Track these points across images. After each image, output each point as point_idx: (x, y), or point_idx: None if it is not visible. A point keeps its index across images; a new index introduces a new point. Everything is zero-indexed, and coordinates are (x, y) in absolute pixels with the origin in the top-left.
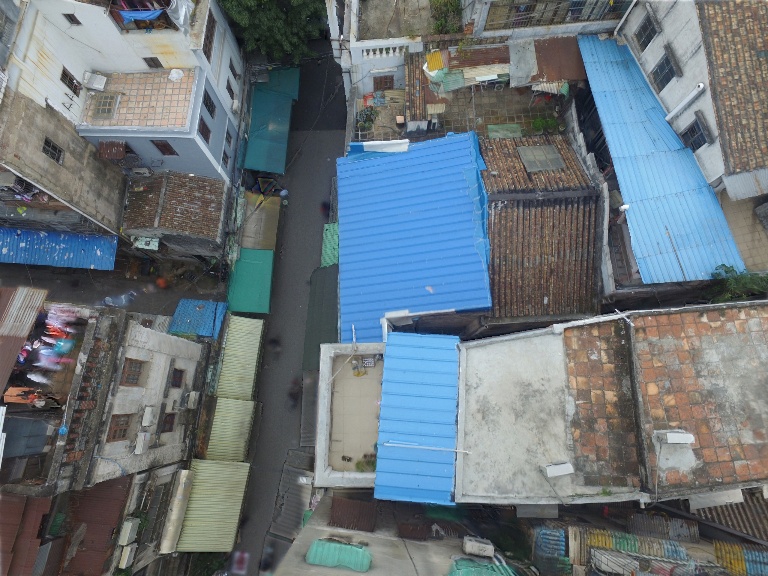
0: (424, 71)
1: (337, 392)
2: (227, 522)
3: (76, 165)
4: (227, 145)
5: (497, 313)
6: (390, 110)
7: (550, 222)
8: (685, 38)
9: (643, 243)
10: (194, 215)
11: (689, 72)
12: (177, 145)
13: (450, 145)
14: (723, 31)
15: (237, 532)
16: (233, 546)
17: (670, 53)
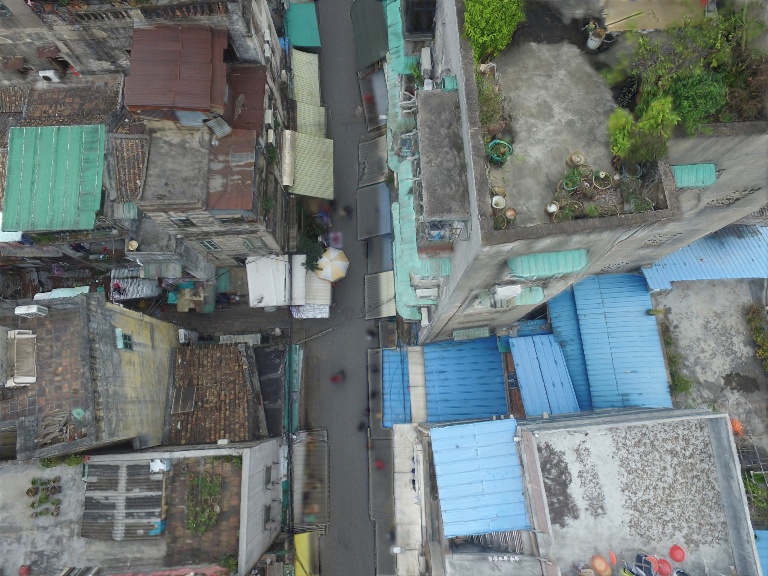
0: None
1: None
2: (325, 179)
3: None
4: None
5: None
6: None
7: None
8: None
9: None
10: None
11: None
12: None
13: None
14: None
15: (334, 188)
16: (333, 197)
17: None
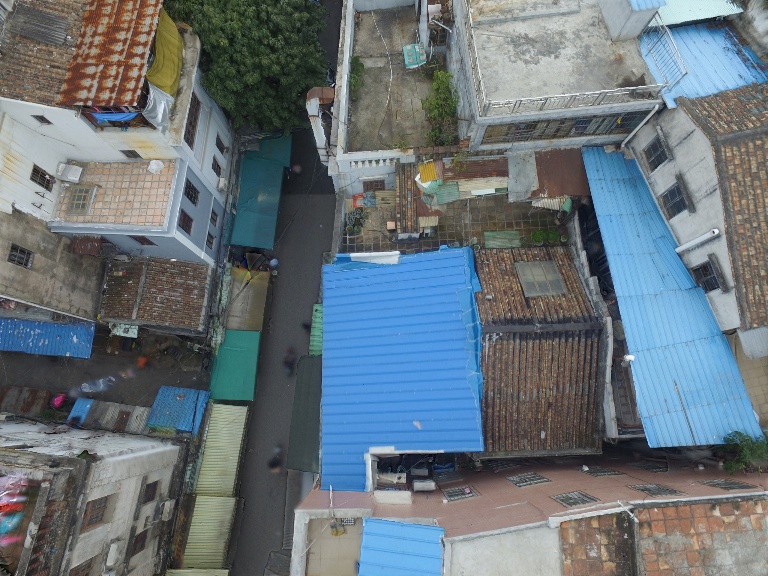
0: (416, 182)
1: (313, 553)
2: None
3: (47, 264)
4: (212, 226)
5: (490, 447)
6: (381, 212)
7: (549, 355)
8: (699, 175)
9: (649, 400)
10: (175, 304)
11: (703, 211)
12: (156, 239)
13: (443, 261)
14: (741, 175)
15: None
16: None
17: (682, 185)
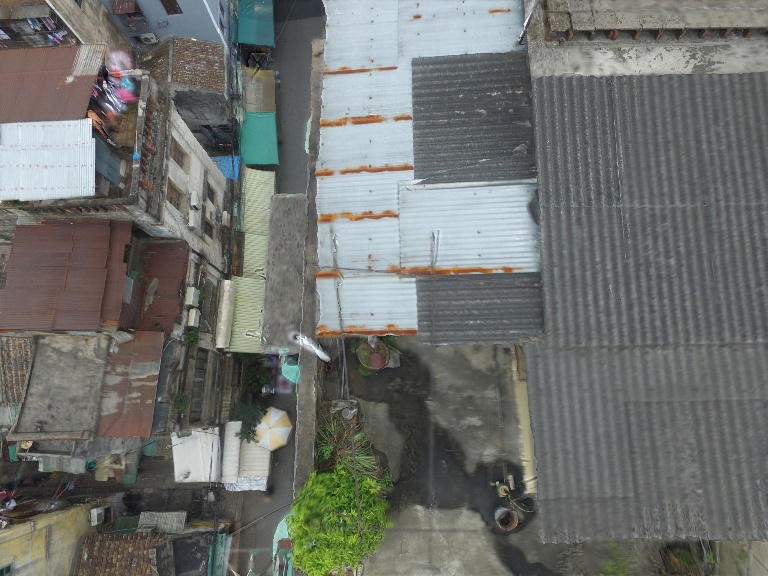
0: None
1: None
2: None
3: (94, 18)
4: (221, 14)
5: None
6: None
7: None
8: None
9: None
10: (201, 73)
11: None
12: None
13: None
14: None
15: None
16: None
17: None
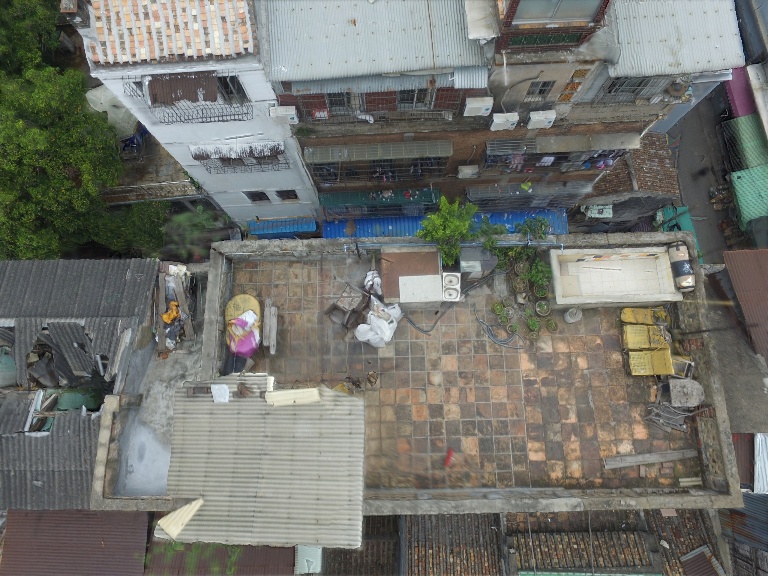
0: None
1: None
2: None
3: None
4: None
5: None
6: None
7: None
8: None
9: None
10: (657, 173)
11: None
12: None
13: None
14: None
15: None
16: None
17: None
